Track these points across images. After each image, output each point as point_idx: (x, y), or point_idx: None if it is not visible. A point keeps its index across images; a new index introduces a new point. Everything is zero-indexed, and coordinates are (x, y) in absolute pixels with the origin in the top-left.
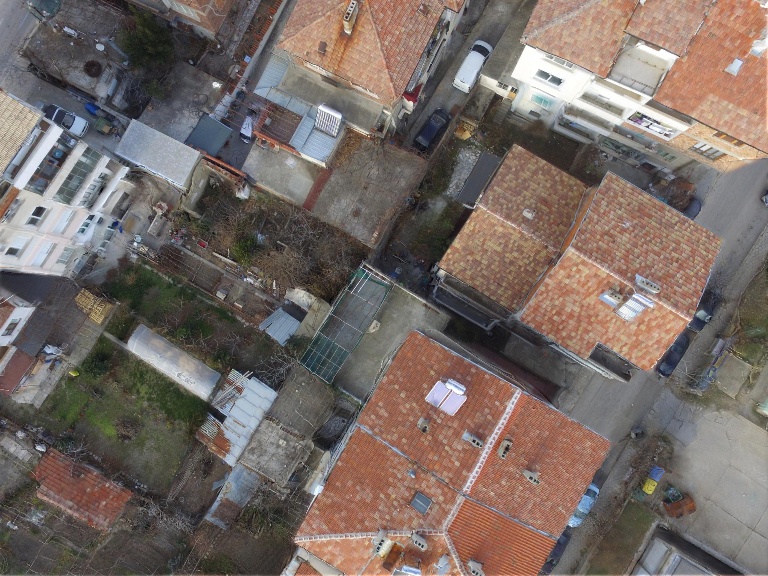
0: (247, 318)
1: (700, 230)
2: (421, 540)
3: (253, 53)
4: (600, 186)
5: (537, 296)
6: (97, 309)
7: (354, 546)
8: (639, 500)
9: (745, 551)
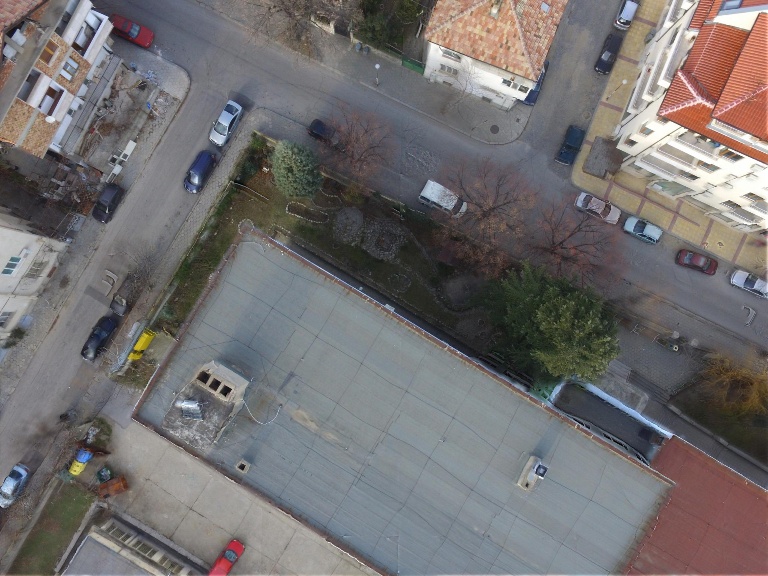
0: None
1: None
2: None
3: None
4: None
5: None
6: None
7: None
8: (66, 480)
9: (182, 529)
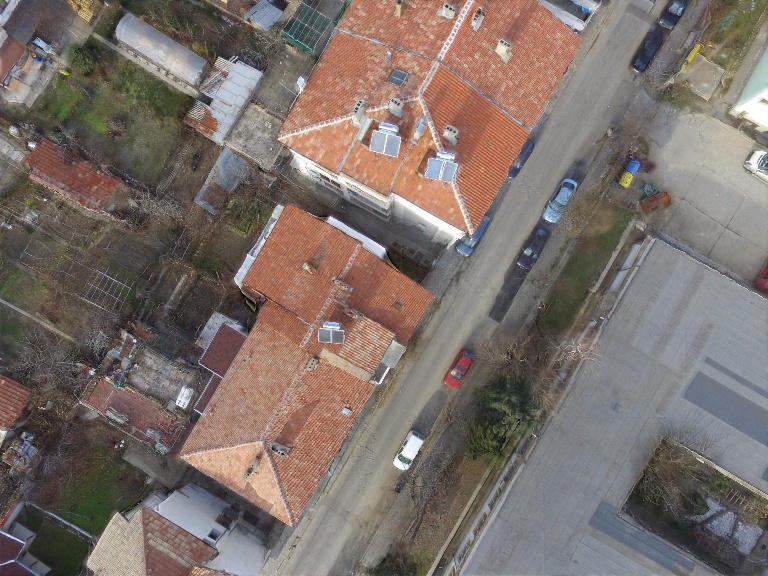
0: (232, 18)
1: None
2: None
3: None
4: None
5: None
6: (85, 4)
7: (334, 133)
8: (615, 193)
9: (719, 247)
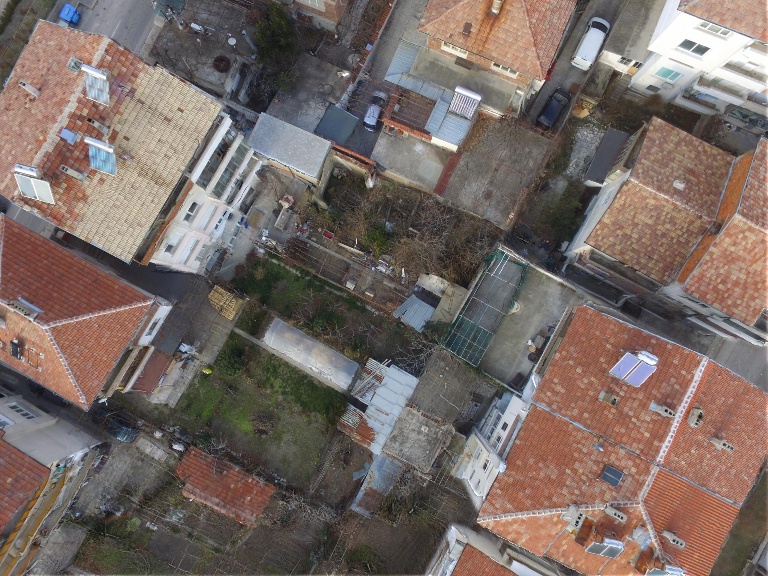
0: (376, 307)
1: None
2: (620, 512)
3: (374, 41)
4: (756, 153)
5: (701, 265)
6: (229, 305)
7: (541, 523)
8: None
9: None
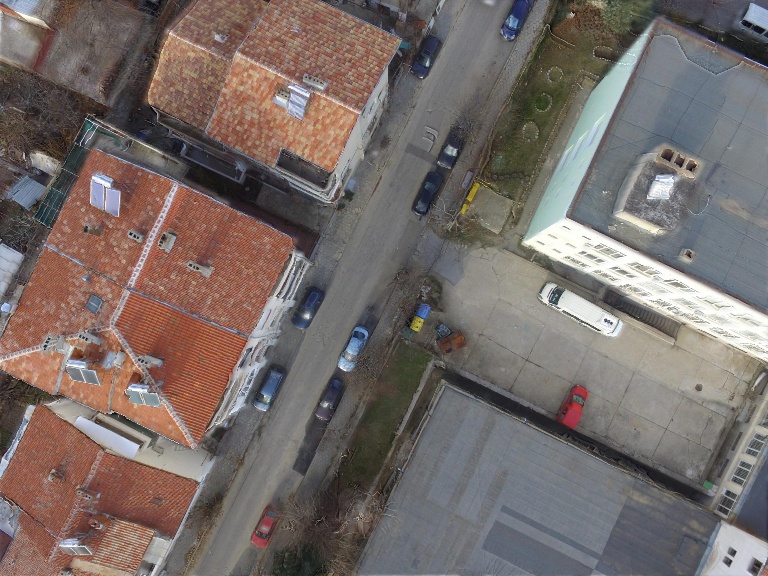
0: (3, 193)
1: (377, 32)
2: (84, 333)
3: None
4: None
5: (218, 108)
6: None
7: (43, 358)
8: (408, 338)
9: (520, 381)
